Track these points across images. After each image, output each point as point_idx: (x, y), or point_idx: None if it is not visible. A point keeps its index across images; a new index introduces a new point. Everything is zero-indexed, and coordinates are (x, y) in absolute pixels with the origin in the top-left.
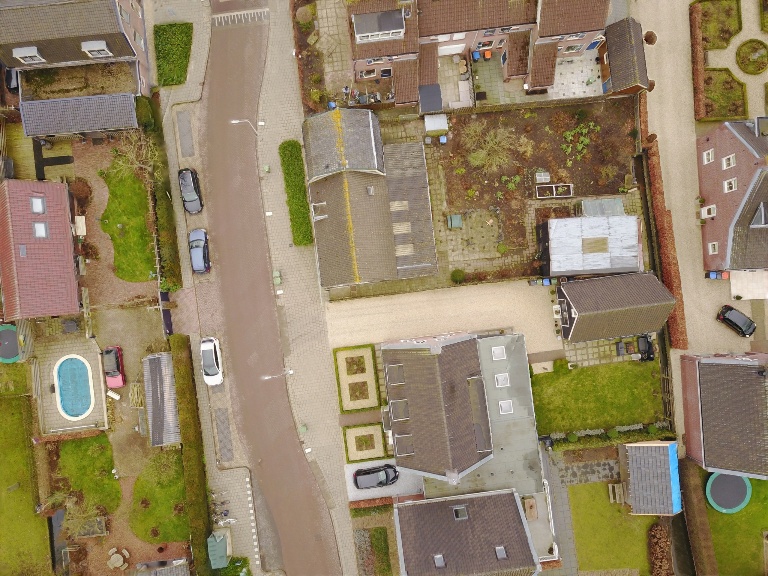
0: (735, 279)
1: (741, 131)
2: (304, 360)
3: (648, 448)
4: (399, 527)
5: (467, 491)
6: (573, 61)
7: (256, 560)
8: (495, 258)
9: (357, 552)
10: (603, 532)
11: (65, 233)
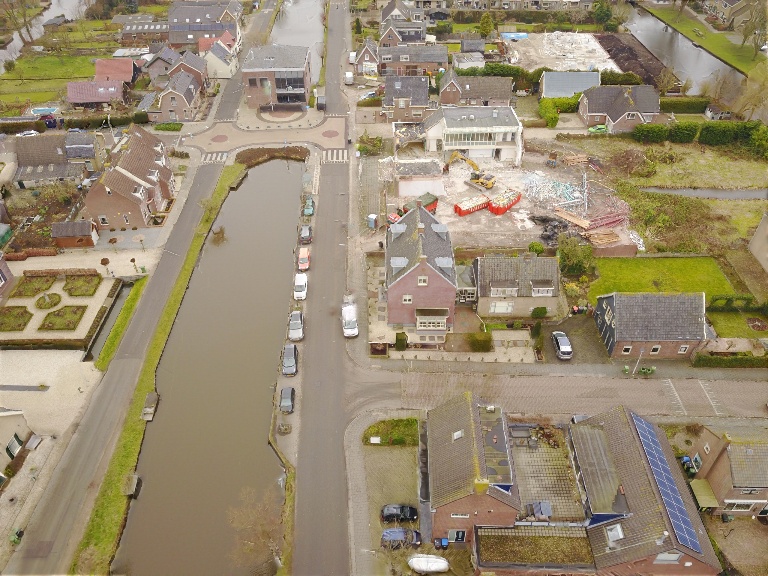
0: None
1: None
2: (8, 157)
3: None
4: None
5: None
6: None
7: None
8: None
9: None
10: None
11: (100, 97)
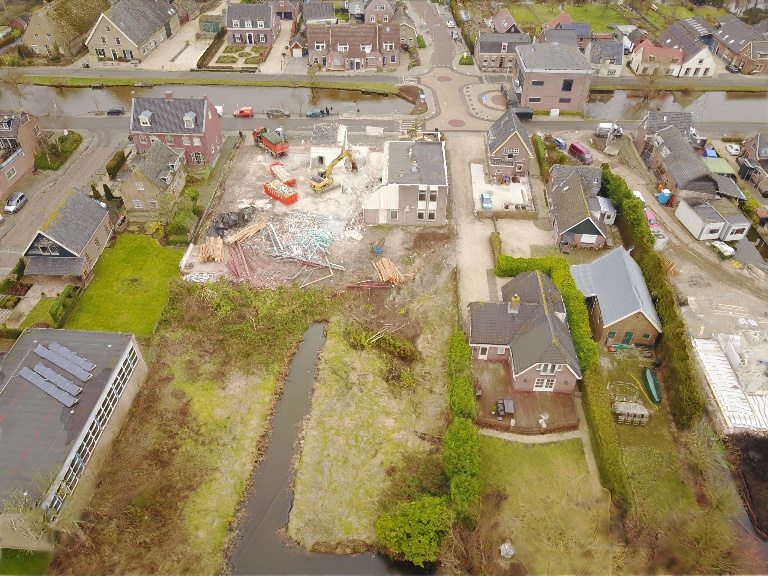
0: None
1: (268, 24)
2: None
3: None
4: None
5: None
6: None
7: (437, 5)
8: None
9: (406, 5)
10: None
11: None
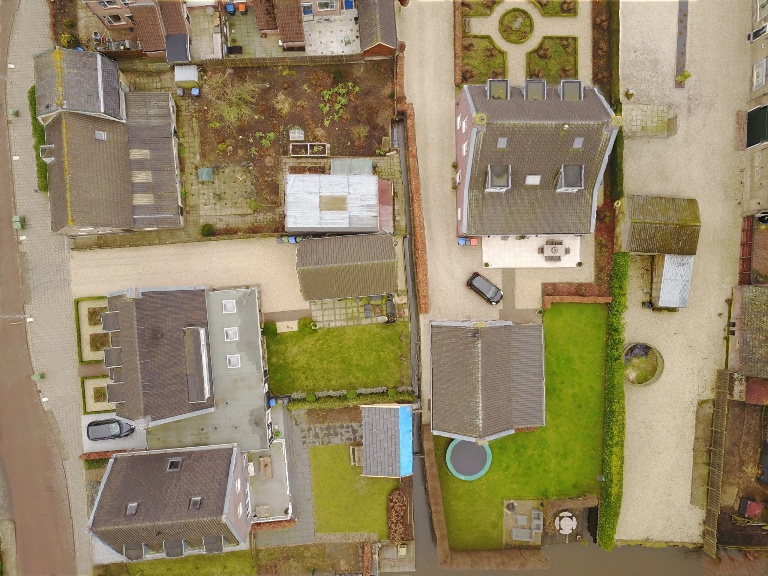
0: (487, 246)
1: (477, 94)
2: (45, 308)
3: (380, 409)
4: (107, 476)
5: (190, 445)
6: (330, 19)
7: None
8: (248, 214)
9: (89, 505)
10: (342, 495)
11: None
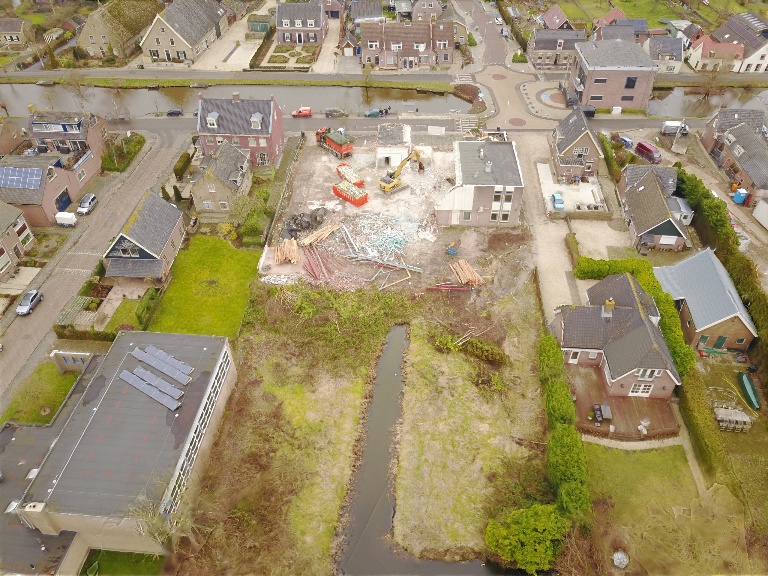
0: None
1: (318, 23)
2: None
3: None
4: None
5: None
6: None
7: (482, 2)
8: None
9: (451, 2)
10: None
11: None
